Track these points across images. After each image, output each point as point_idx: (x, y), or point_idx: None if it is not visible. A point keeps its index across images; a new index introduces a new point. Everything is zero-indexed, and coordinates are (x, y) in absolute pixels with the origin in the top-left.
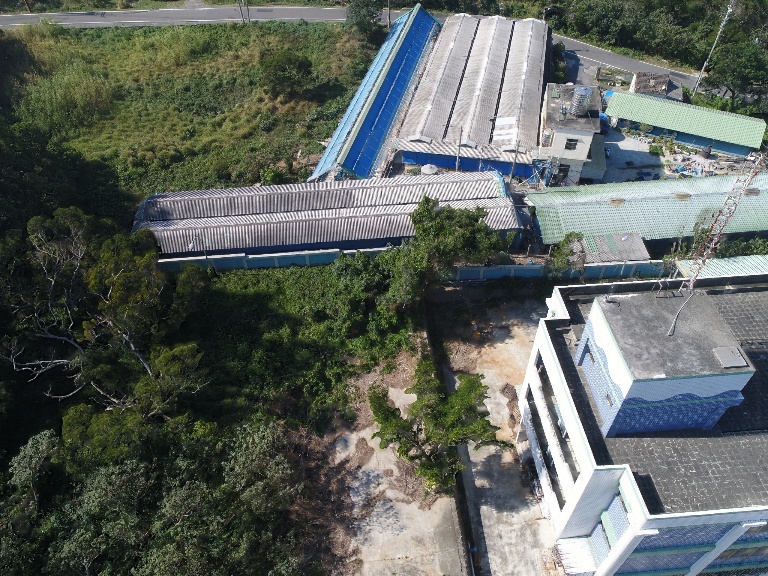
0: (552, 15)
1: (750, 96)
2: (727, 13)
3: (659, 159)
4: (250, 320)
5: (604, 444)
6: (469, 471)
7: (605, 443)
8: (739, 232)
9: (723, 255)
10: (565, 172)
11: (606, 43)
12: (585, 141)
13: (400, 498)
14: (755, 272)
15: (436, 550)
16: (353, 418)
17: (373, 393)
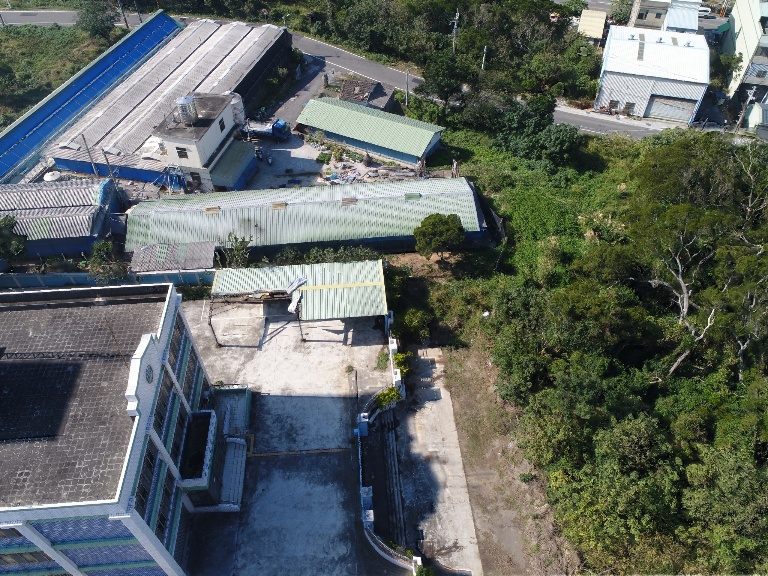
0: (316, 21)
1: (459, 104)
2: (455, 21)
3: (321, 167)
4: None
5: None
6: None
7: None
8: (321, 241)
9: (274, 264)
10: (198, 180)
11: (362, 49)
12: (192, 150)
13: None
14: (281, 282)
15: None
16: None
17: None
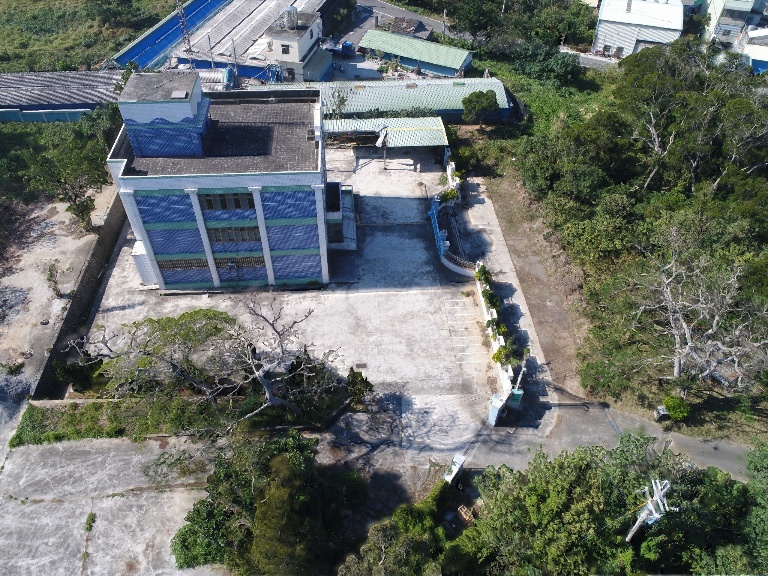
0: None
1: (485, 39)
2: None
3: (382, 74)
4: (6, 145)
5: (133, 160)
6: (126, 231)
7: (134, 160)
8: None
9: None
10: (293, 75)
11: (402, 3)
12: (294, 46)
13: (62, 234)
14: (371, 126)
15: (72, 257)
16: (53, 197)
17: (38, 158)
